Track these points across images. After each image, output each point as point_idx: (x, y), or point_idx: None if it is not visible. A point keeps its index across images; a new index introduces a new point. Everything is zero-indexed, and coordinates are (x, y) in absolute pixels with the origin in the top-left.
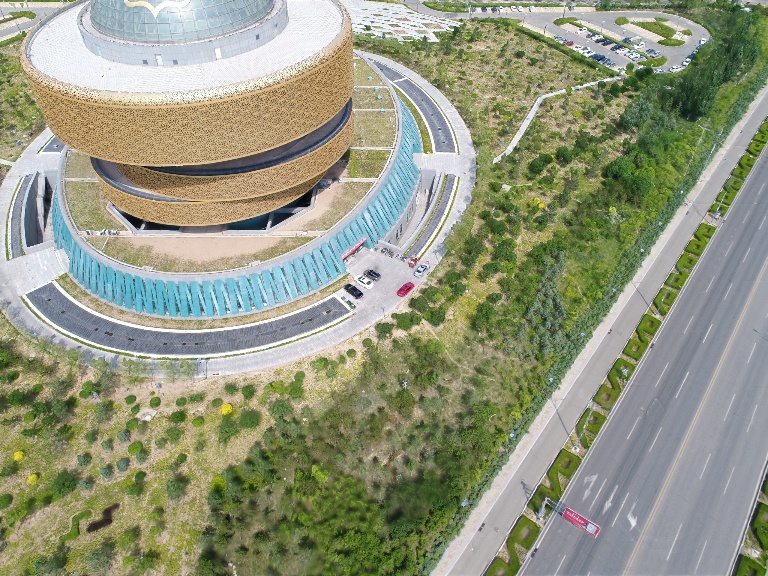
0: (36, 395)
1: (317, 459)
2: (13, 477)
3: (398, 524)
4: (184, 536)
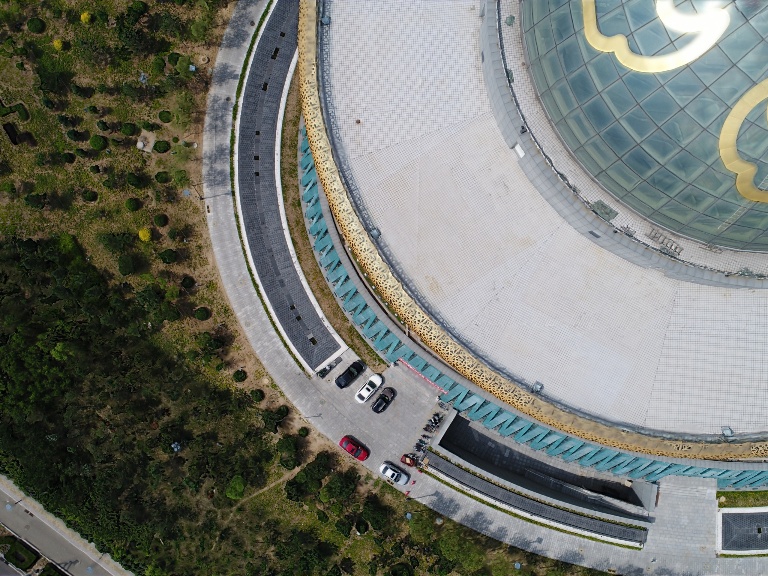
0: (171, 1)
1: (86, 346)
2: (64, 22)
3: (4, 435)
4: (8, 220)
